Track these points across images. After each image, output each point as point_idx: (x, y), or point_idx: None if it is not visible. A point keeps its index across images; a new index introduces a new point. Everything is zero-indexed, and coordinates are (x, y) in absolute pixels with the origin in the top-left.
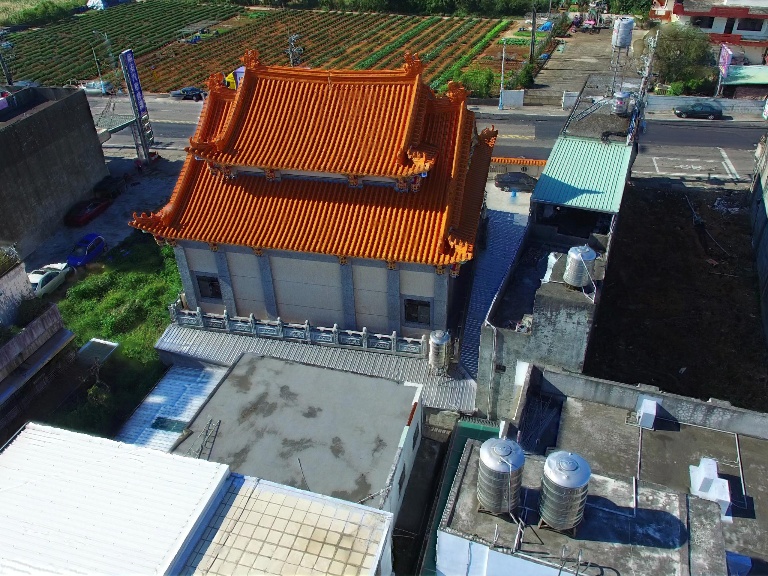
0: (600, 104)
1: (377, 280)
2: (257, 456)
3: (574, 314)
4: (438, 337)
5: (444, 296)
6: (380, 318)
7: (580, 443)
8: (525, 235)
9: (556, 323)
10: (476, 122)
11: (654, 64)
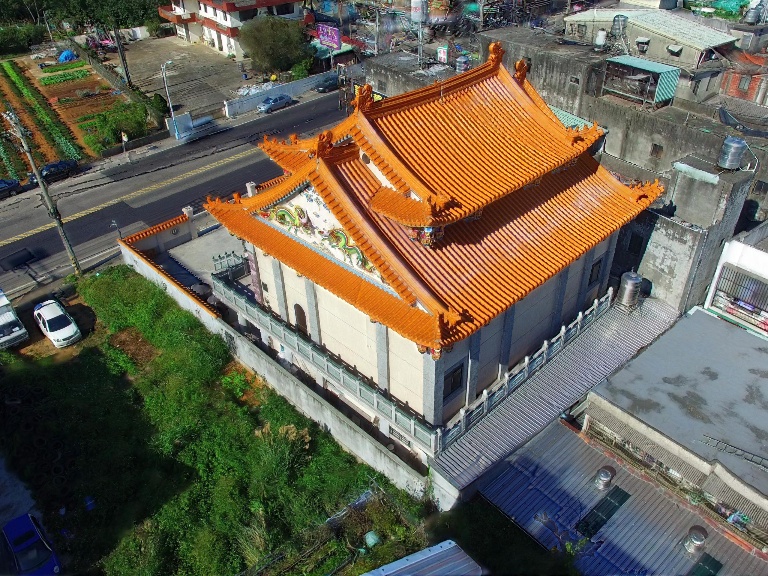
0: (433, 75)
1: (579, 262)
2: (765, 423)
3: None
4: (637, 277)
5: None
6: None
7: None
8: None
9: None
10: (183, 157)
11: (380, 40)
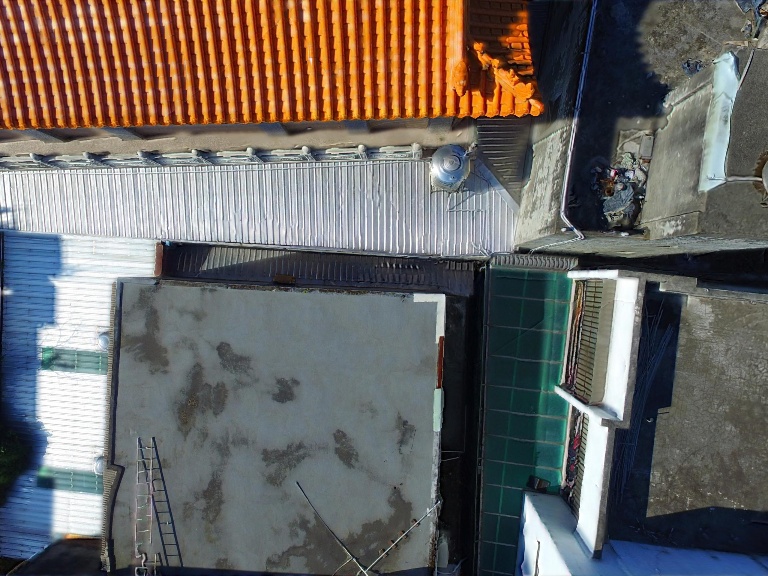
0: None
1: None
2: (236, 491)
3: (761, 242)
4: (449, 172)
5: None
6: None
7: (707, 392)
8: None
9: None
10: None
11: None
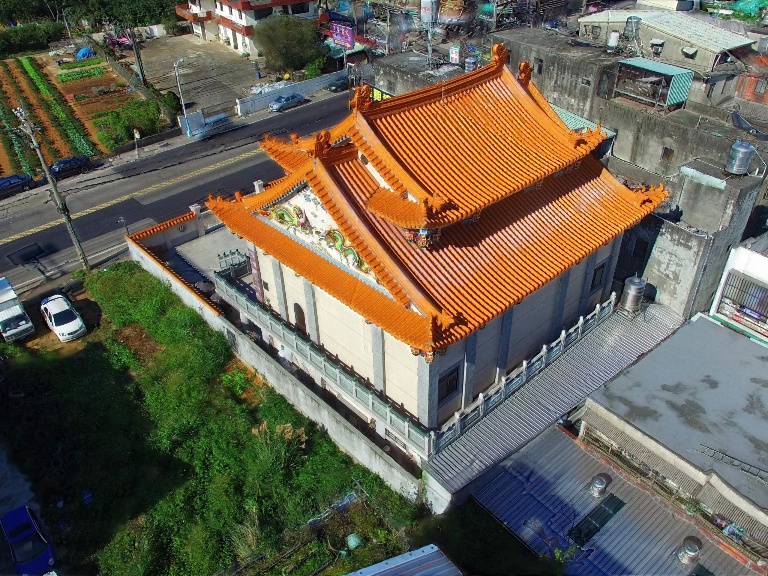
0: (442, 75)
1: (581, 266)
2: (765, 434)
3: (752, 193)
4: (640, 282)
5: (619, 248)
6: (574, 304)
7: None
8: None
9: (742, 207)
10: (194, 155)
11: (390, 40)
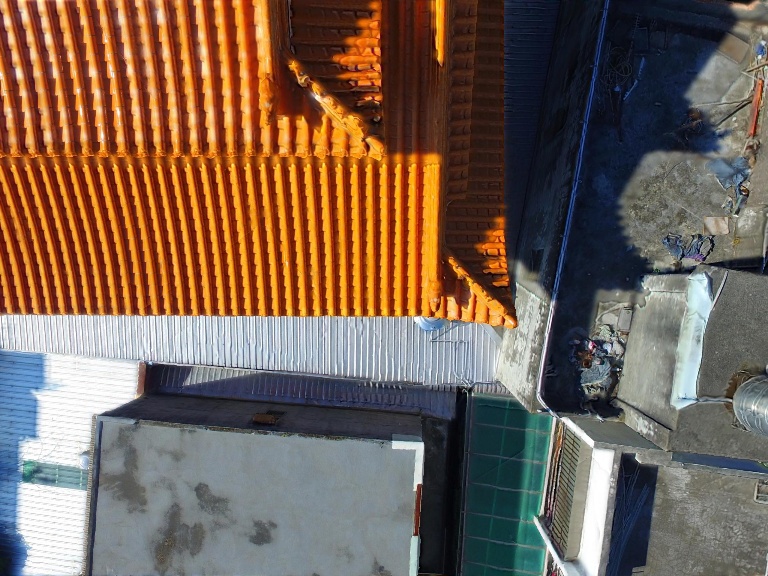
0: None
1: None
2: None
3: None
4: (430, 322)
5: None
6: None
7: (682, 552)
8: (602, 41)
9: None
10: None
11: None
